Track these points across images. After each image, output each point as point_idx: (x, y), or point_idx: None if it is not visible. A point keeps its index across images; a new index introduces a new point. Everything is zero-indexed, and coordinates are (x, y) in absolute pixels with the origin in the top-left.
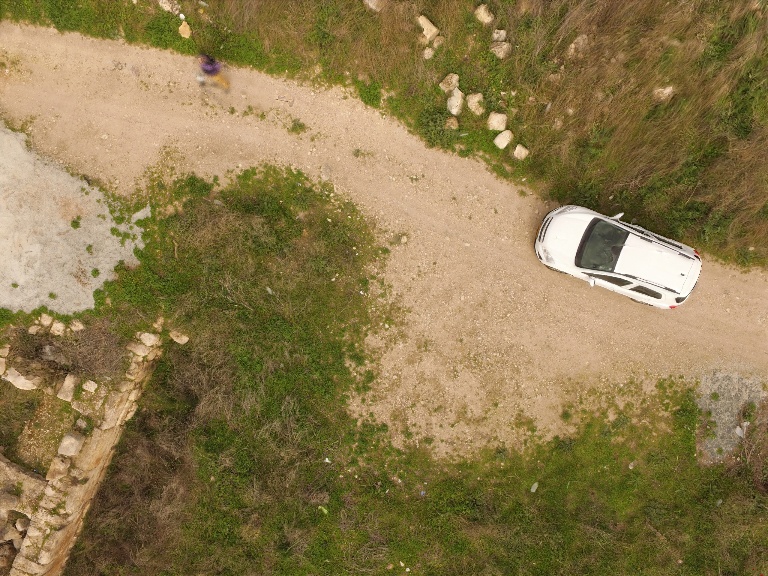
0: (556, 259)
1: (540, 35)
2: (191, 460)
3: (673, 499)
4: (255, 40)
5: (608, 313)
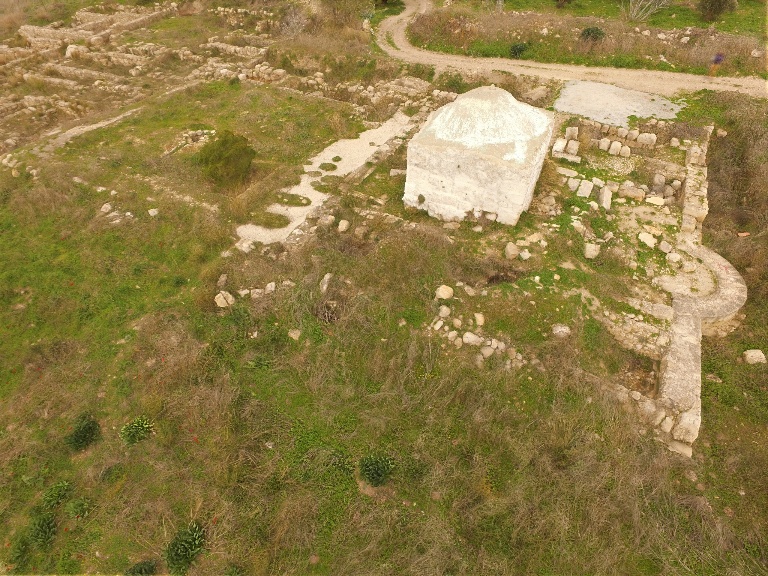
0: None
1: None
2: None
3: None
4: None
5: None
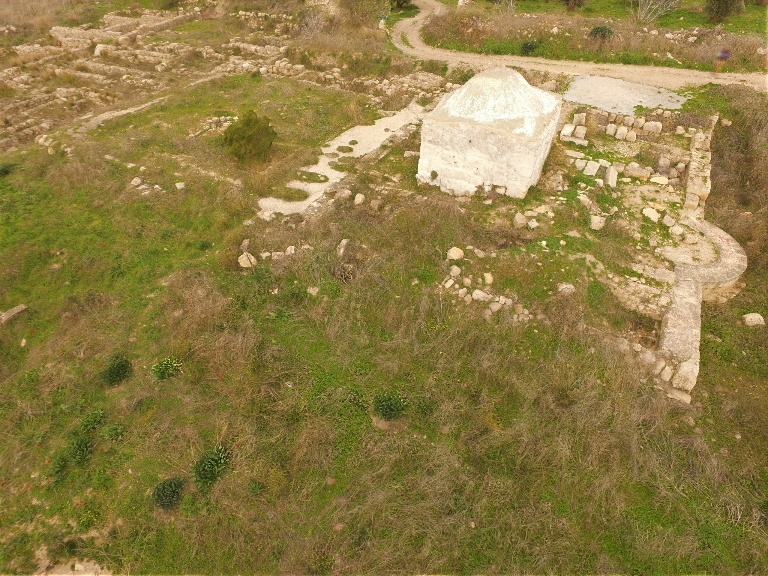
0: None
1: None
2: None
3: None
4: None
5: None
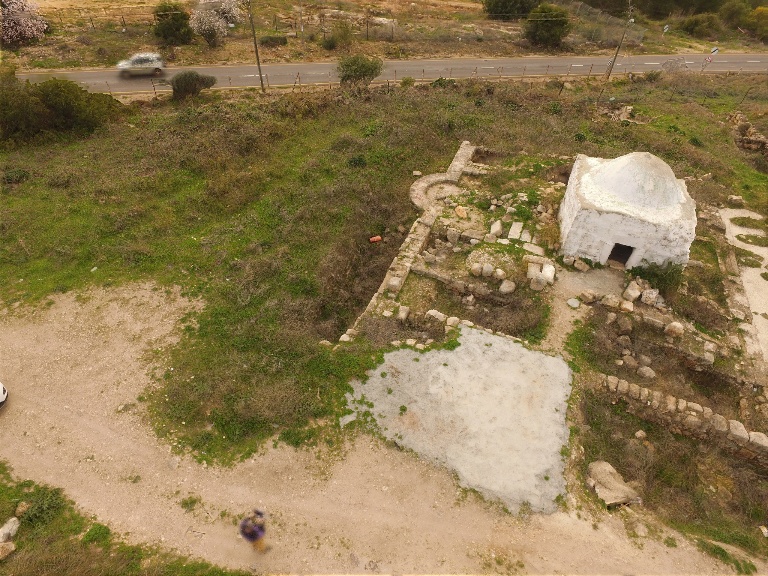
0: None
1: None
2: None
3: (4, 266)
4: None
5: None
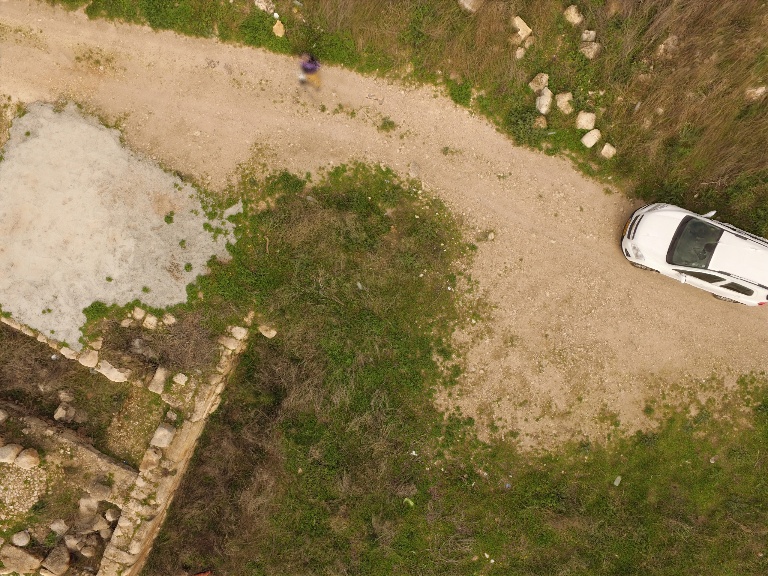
0: (647, 256)
1: (629, 36)
2: (279, 452)
3: (754, 493)
4: (348, 39)
5: (690, 310)
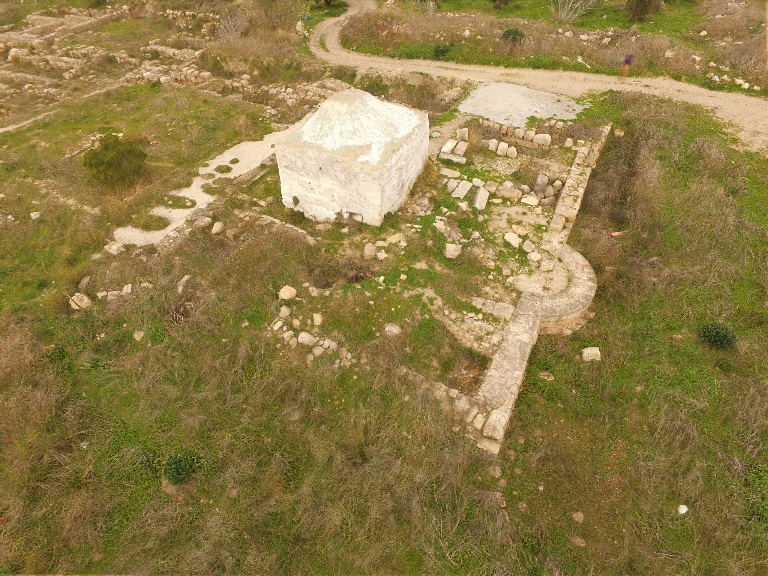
0: None
1: None
2: None
3: None
4: None
5: None
